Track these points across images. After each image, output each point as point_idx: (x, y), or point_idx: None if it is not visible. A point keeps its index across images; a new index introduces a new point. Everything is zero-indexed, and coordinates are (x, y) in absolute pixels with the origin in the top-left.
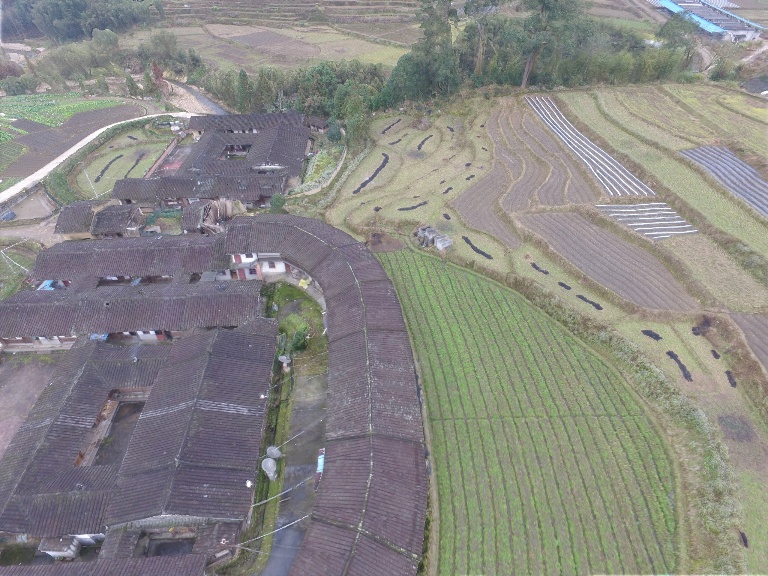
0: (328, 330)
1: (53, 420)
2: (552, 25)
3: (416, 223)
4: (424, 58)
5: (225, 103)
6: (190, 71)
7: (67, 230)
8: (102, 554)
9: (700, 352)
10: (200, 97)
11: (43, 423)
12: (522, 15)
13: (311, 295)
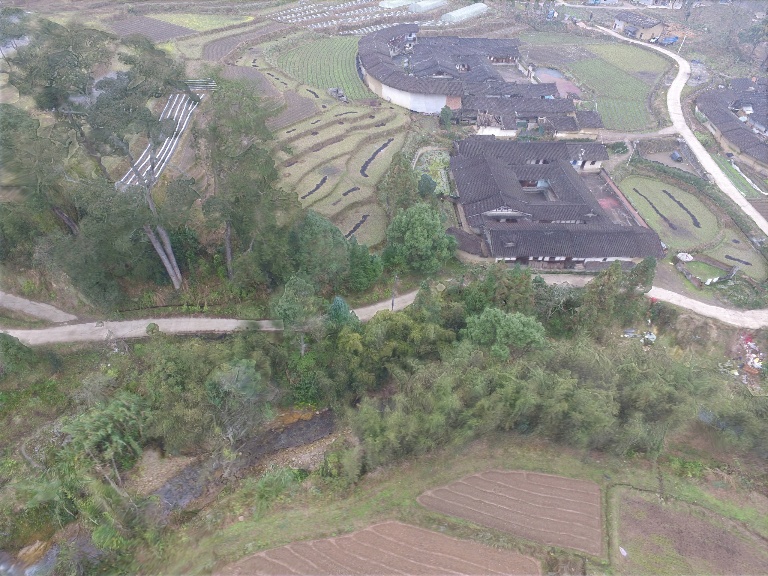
0: None
1: None
2: None
3: None
4: None
5: None
6: None
7: None
8: None
9: (242, 62)
10: None
11: None
12: None
13: None
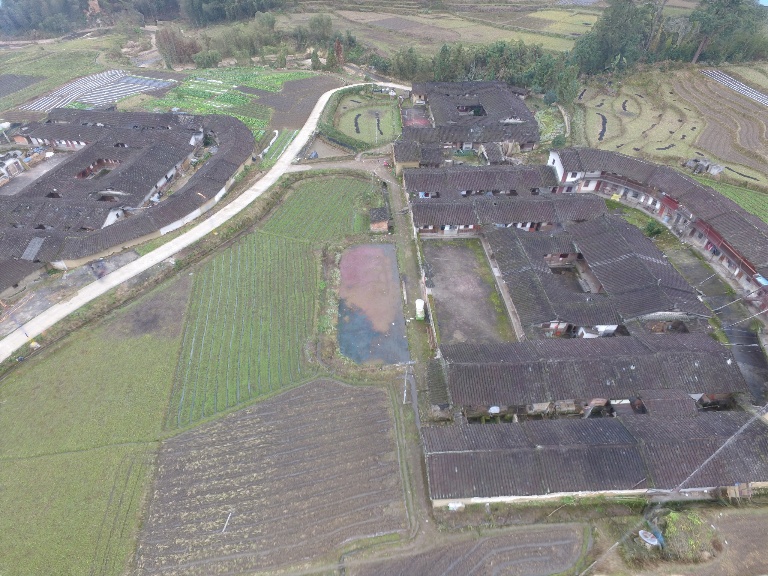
0: (696, 214)
1: (532, 266)
2: (740, 8)
3: (678, 158)
4: (612, 36)
5: (396, 77)
6: (346, 51)
7: (406, 159)
8: (634, 333)
9: None
10: (365, 73)
11: (523, 269)
12: (694, 1)
13: (627, 205)
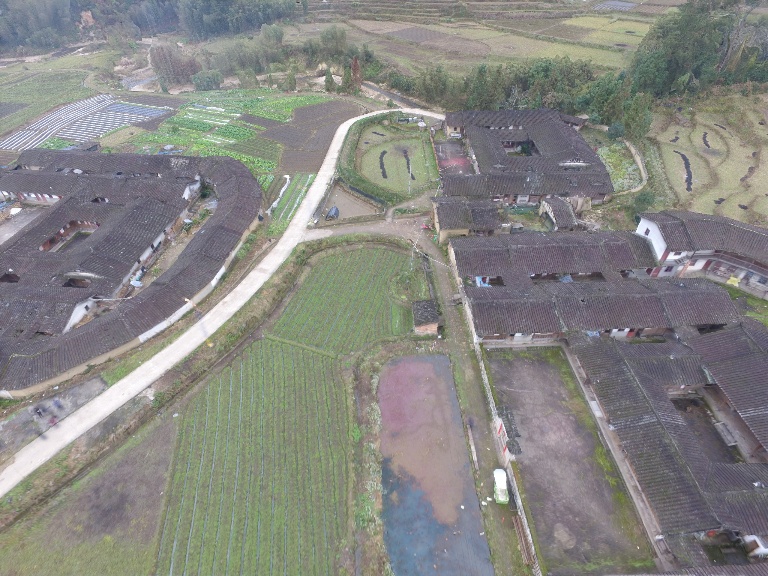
0: None
1: (659, 417)
2: None
3: None
4: (685, 55)
5: (422, 99)
6: (362, 67)
7: (453, 226)
8: None
9: None
10: (385, 93)
11: (645, 420)
12: None
13: (750, 293)
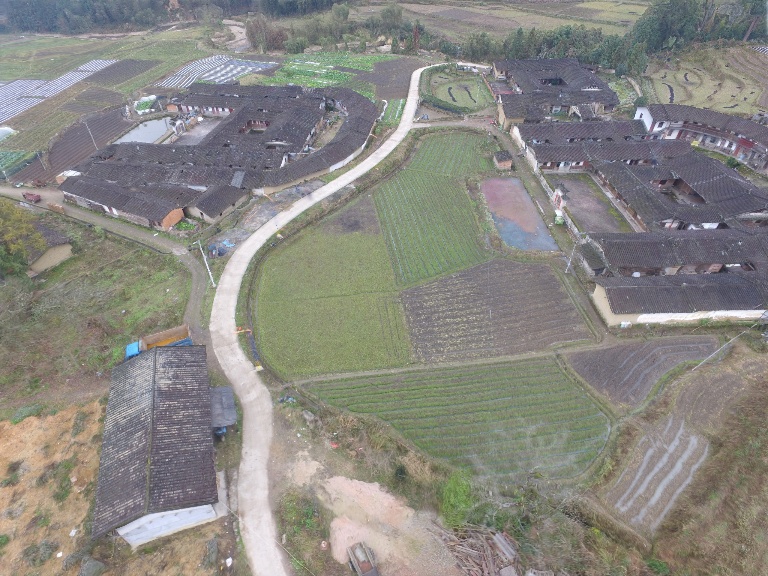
0: None
1: (644, 185)
2: None
3: (743, 114)
4: (672, 18)
5: (467, 60)
6: None
7: (514, 116)
8: (733, 227)
9: None
10: None
11: (637, 188)
12: None
13: (705, 149)
